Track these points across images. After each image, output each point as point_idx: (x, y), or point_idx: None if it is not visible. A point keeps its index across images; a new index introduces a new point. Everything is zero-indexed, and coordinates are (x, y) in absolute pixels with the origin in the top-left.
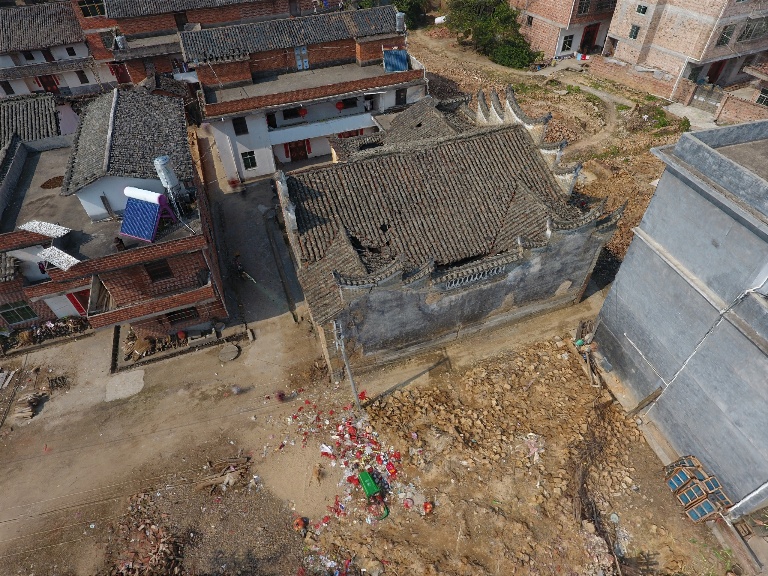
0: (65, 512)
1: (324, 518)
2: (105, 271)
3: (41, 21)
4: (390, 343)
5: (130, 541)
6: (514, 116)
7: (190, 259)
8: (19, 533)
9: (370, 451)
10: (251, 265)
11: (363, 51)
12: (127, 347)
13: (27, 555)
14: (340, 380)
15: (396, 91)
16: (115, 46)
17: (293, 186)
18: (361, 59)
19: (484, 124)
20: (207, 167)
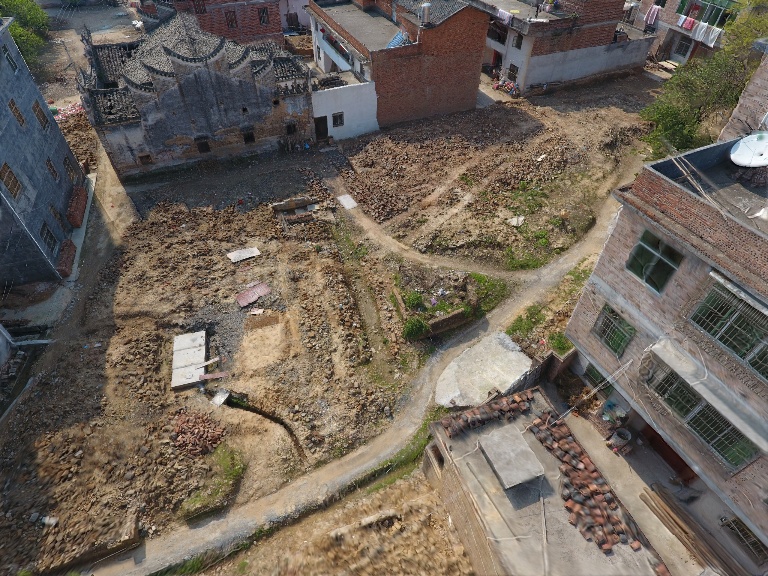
0: None
1: None
2: None
3: None
4: None
5: None
6: None
7: None
8: None
9: None
10: None
11: None
12: None
13: None
14: None
15: None
16: None
17: None
18: None
19: None
20: None
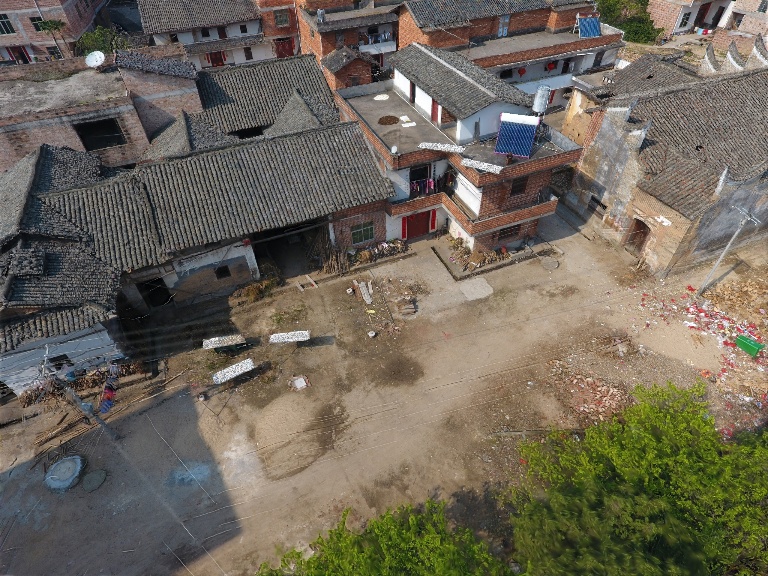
0: (499, 375)
1: (722, 369)
2: (510, 178)
3: (217, 0)
4: (712, 244)
5: (571, 391)
6: (763, 62)
7: (542, 176)
8: (472, 390)
9: (728, 324)
10: None
11: (558, 19)
12: (462, 260)
13: (492, 404)
14: (663, 278)
15: (596, 53)
16: None
17: None
18: (555, 27)
19: (711, 74)
20: None
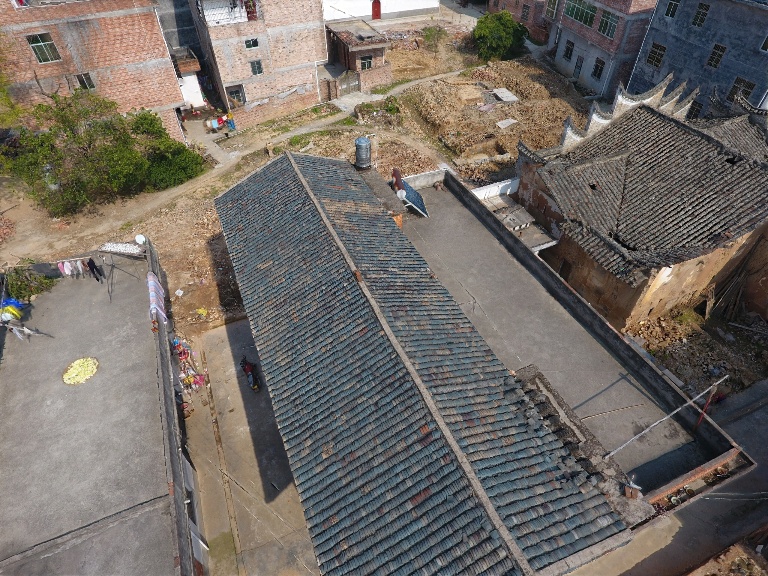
0: None
1: None
2: None
3: None
4: None
5: None
6: (629, 104)
7: None
8: None
9: None
10: None
11: None
12: None
13: None
14: None
15: None
16: None
17: None
18: None
19: (577, 144)
20: None
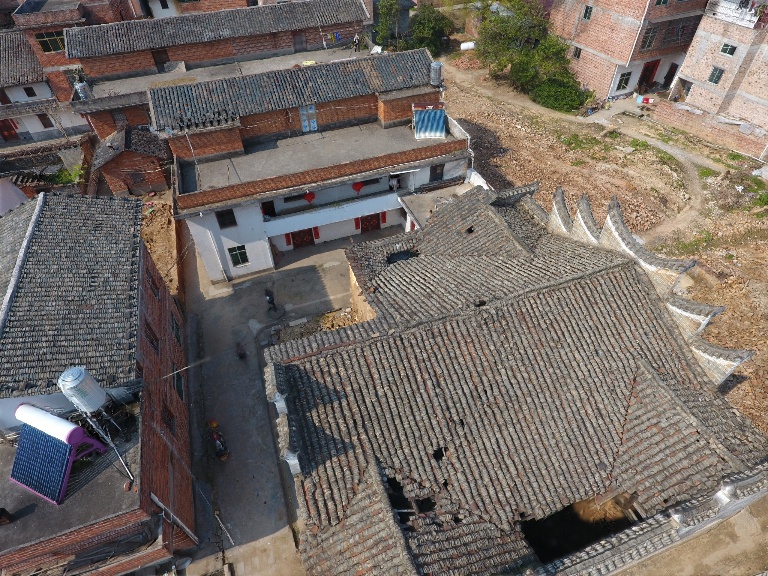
0: None
1: None
2: None
3: None
4: None
5: None
6: (619, 242)
7: None
8: None
9: None
10: (235, 430)
11: (387, 110)
12: None
13: None
14: None
15: (431, 166)
16: (76, 94)
17: (294, 382)
18: (384, 119)
19: (562, 234)
20: (186, 255)
